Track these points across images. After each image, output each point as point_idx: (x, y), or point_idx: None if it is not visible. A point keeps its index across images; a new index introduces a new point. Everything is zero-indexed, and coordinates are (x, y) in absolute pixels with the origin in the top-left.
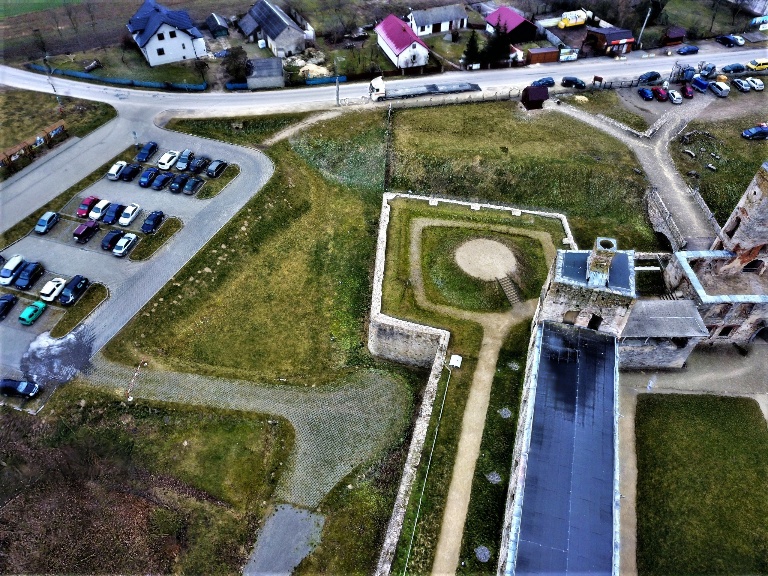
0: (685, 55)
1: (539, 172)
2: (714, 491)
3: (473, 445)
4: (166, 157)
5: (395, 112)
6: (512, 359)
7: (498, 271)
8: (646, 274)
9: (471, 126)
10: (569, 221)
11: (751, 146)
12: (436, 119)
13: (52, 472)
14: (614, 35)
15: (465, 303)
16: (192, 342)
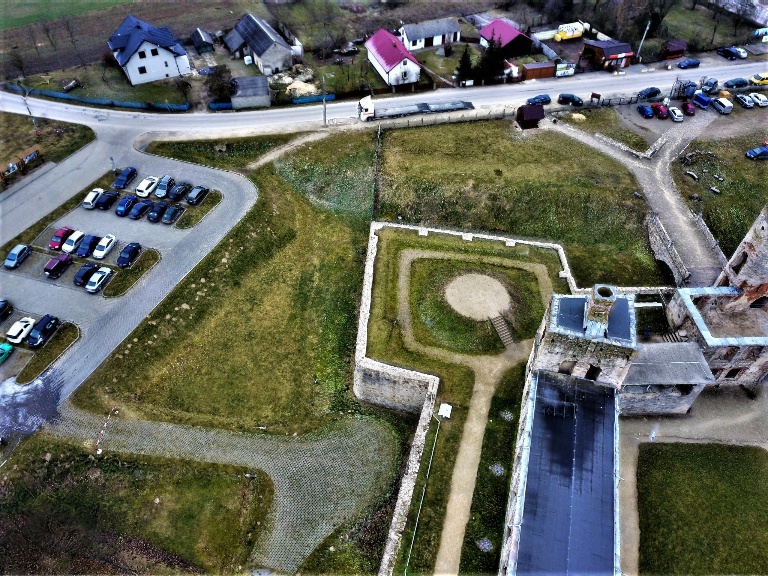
0: (686, 69)
1: (535, 197)
2: (722, 554)
3: (463, 507)
4: (144, 184)
5: (385, 133)
6: (505, 408)
7: (490, 310)
8: (647, 311)
9: (464, 147)
10: (566, 248)
11: (756, 167)
12: (427, 140)
13: (13, 534)
14: (612, 49)
15: (455, 345)
16: (167, 386)
